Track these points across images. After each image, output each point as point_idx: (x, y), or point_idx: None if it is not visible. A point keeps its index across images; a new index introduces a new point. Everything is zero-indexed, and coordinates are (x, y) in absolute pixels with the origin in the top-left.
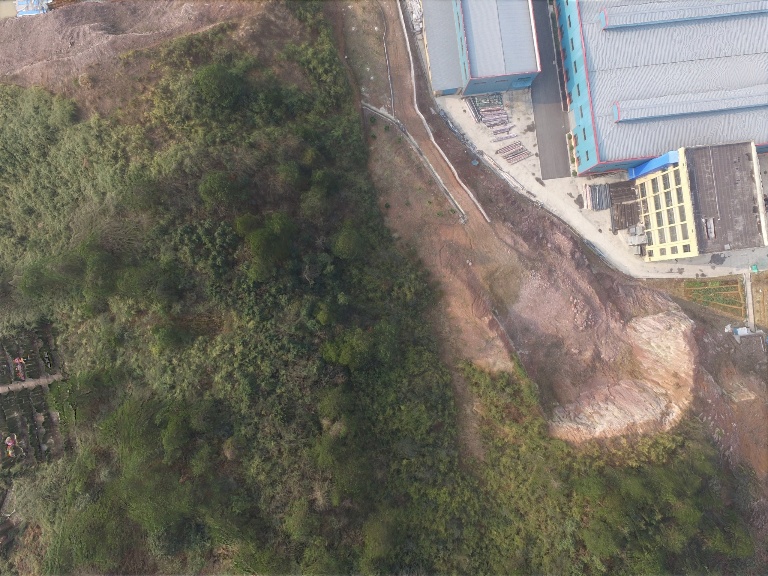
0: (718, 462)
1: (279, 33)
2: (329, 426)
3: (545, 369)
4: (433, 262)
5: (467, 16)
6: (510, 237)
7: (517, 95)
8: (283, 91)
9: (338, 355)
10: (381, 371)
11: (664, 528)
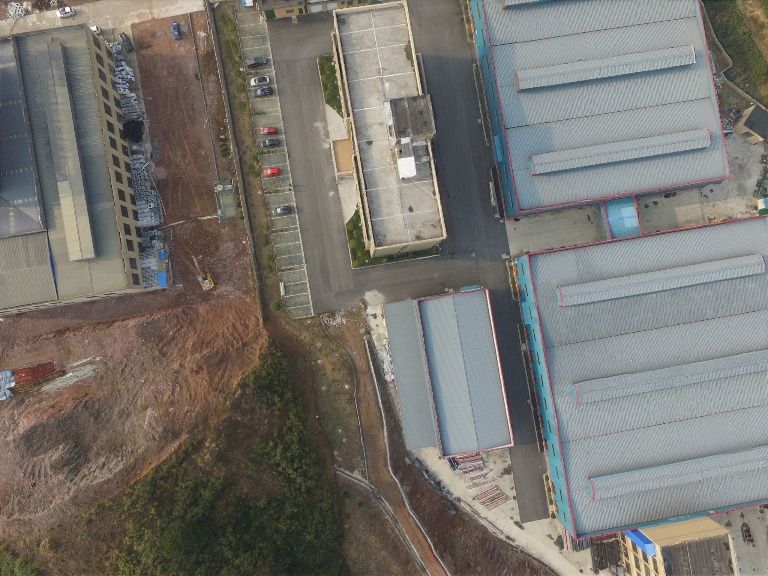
0: None
1: (246, 433)
2: None
3: None
4: None
5: (437, 391)
6: None
7: None
8: (252, 512)
9: None
10: None
11: None
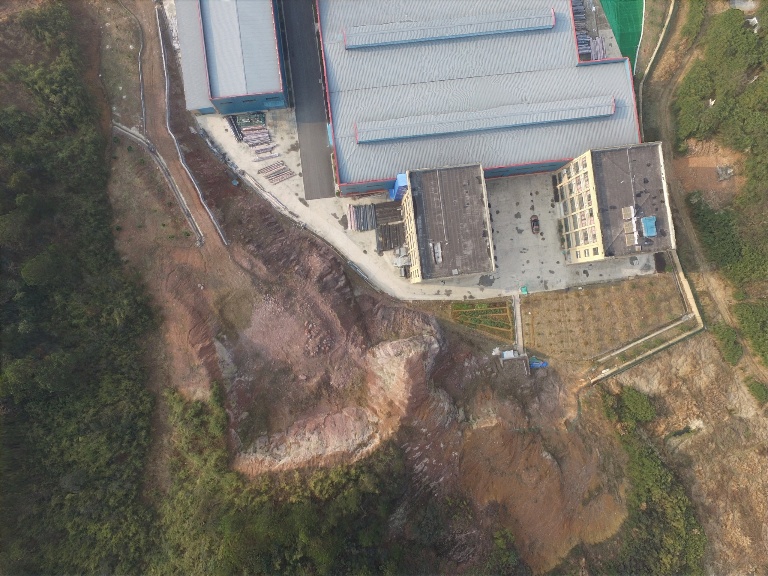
0: (412, 495)
1: (6, 53)
2: None
3: (266, 396)
4: (158, 286)
5: (209, 35)
6: (247, 260)
7: (281, 114)
8: None
9: None
10: (66, 401)
11: (300, 568)
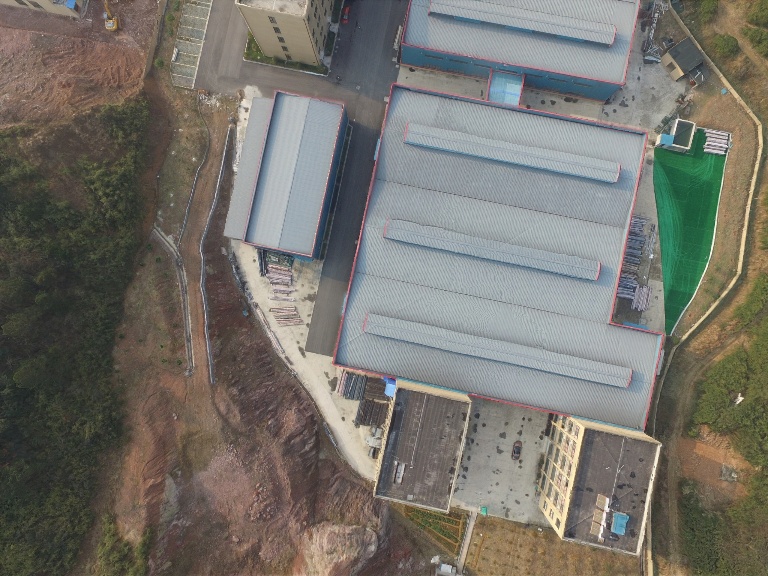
0: None
1: (77, 146)
2: None
3: (195, 547)
4: (136, 406)
5: (263, 181)
6: (225, 405)
7: (309, 262)
8: (48, 206)
9: None
10: (14, 503)
11: None
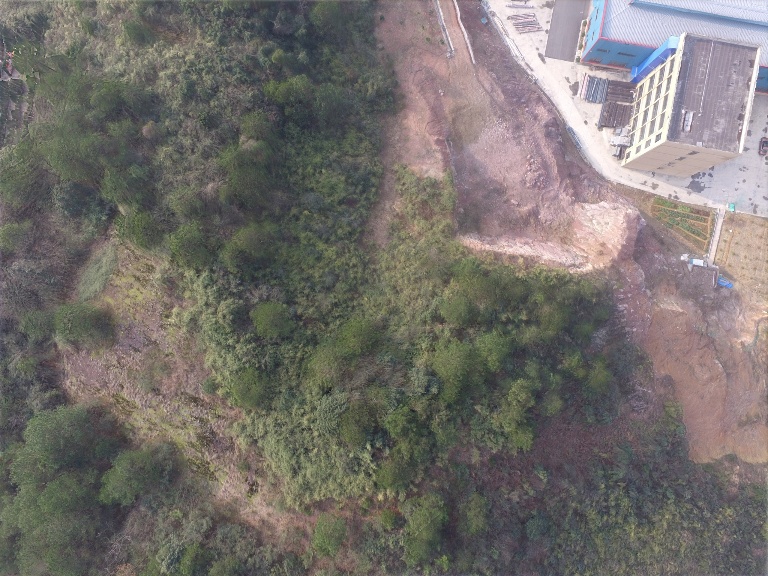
0: (613, 326)
1: None
2: (244, 142)
3: (478, 206)
4: (406, 78)
5: None
6: (489, 83)
7: None
8: None
9: (276, 89)
10: (316, 137)
11: (524, 328)
